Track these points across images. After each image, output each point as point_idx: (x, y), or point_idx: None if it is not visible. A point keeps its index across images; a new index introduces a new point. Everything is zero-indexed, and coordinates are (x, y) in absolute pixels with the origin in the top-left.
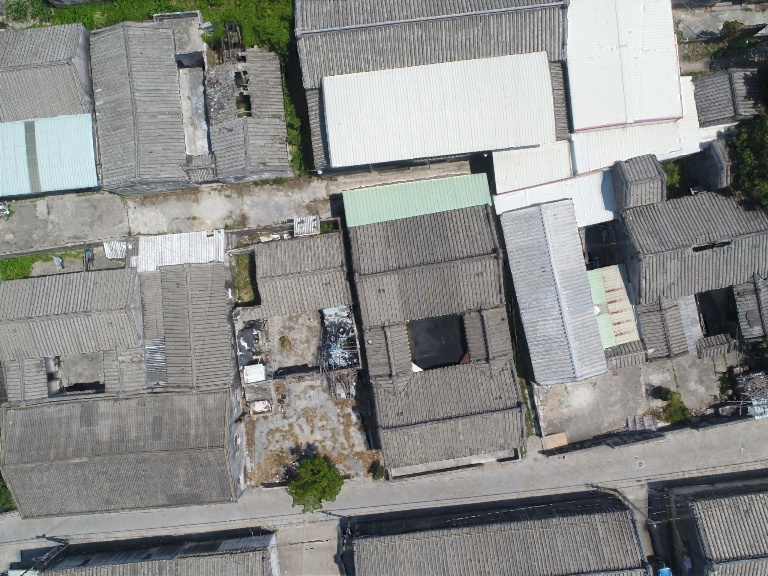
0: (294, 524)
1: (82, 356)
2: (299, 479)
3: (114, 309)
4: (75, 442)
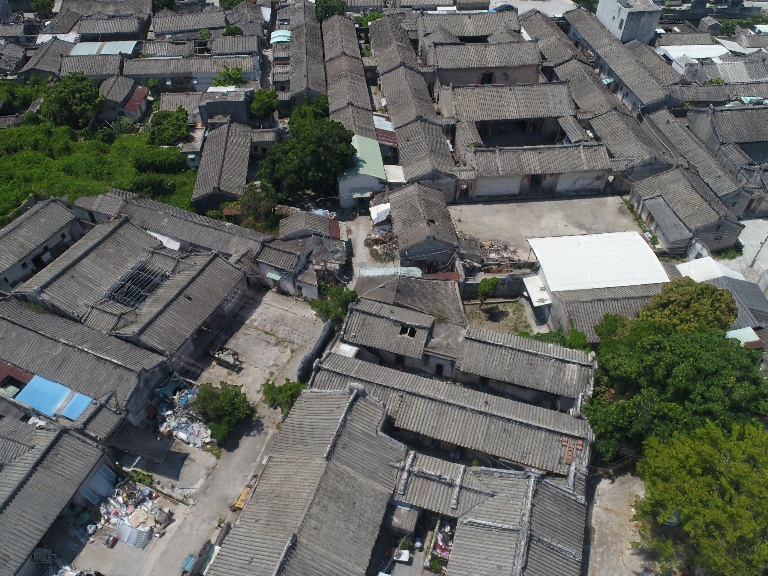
0: None
1: None
2: (54, 16)
3: (86, 20)
4: (123, 5)
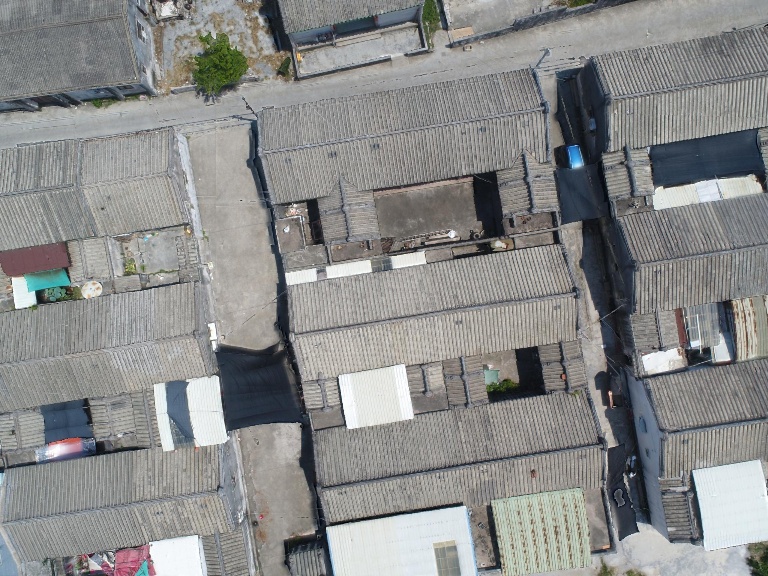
0: (206, 130)
1: None
2: None
3: None
4: None
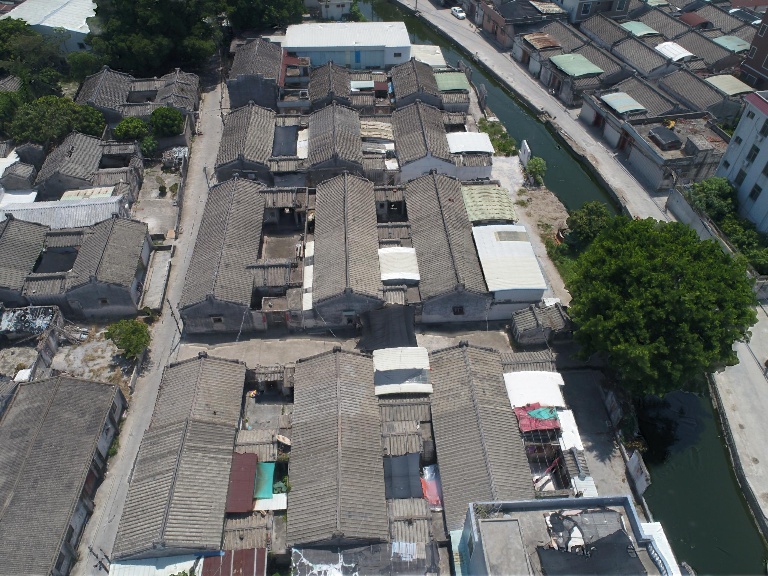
0: None
1: None
2: None
3: None
4: None
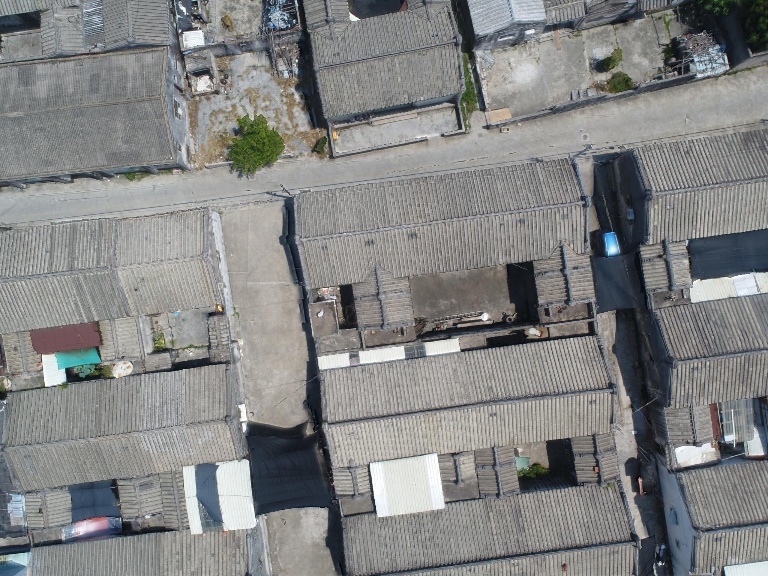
0: (239, 206)
1: (23, 42)
2: None
3: None
4: (12, 100)
